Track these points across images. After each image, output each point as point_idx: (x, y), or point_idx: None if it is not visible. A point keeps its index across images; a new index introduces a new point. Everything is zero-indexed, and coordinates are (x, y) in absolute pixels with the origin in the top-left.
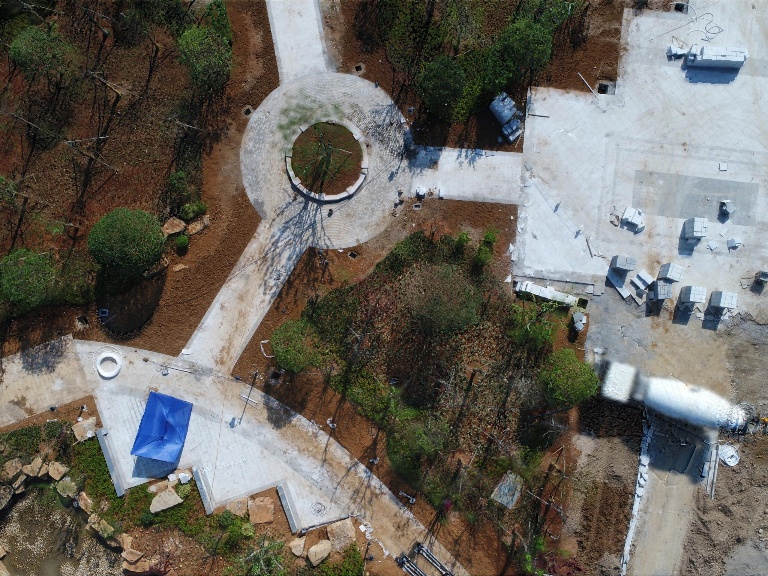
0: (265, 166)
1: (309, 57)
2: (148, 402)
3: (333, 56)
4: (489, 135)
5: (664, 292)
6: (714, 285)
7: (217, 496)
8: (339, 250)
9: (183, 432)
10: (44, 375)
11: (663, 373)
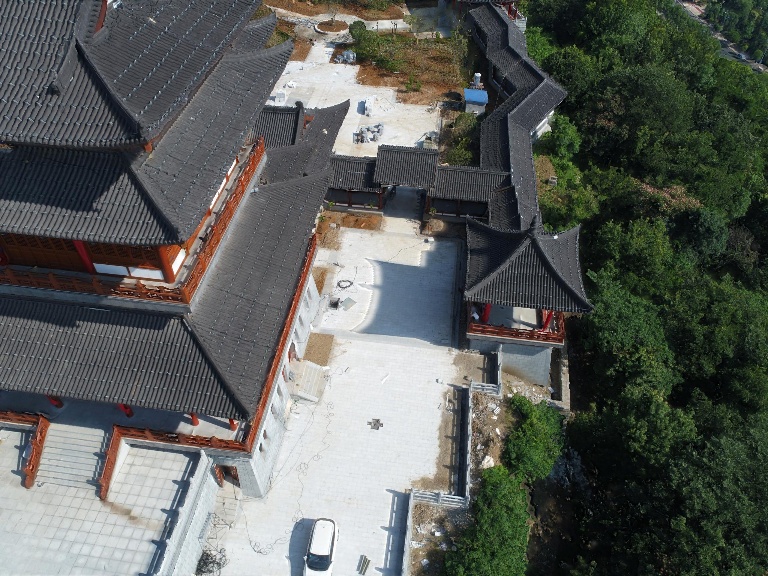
0: None
1: None
2: None
3: None
4: None
5: None
6: None
7: None
8: (293, 29)
9: None
10: None
11: None
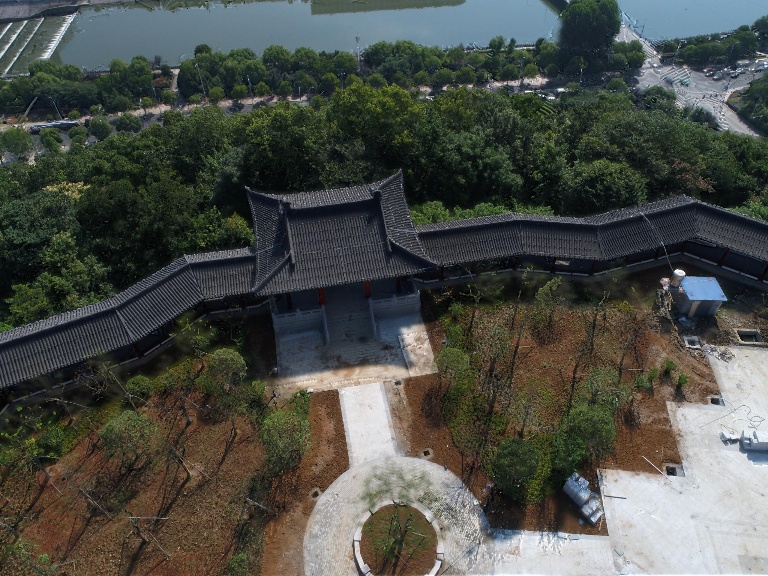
0: (330, 552)
1: (379, 443)
2: None
3: (401, 442)
4: (568, 517)
5: None
6: None
7: None
8: None
9: None
10: None
11: None
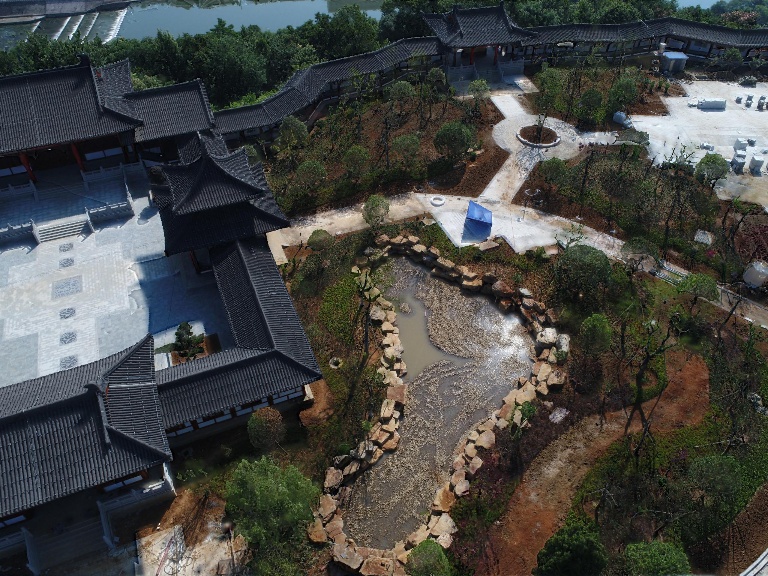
0: (507, 139)
1: None
2: (470, 203)
3: (528, 111)
4: (617, 127)
5: (740, 160)
6: (765, 164)
7: (519, 249)
8: None
9: (490, 222)
10: (399, 206)
11: (762, 193)
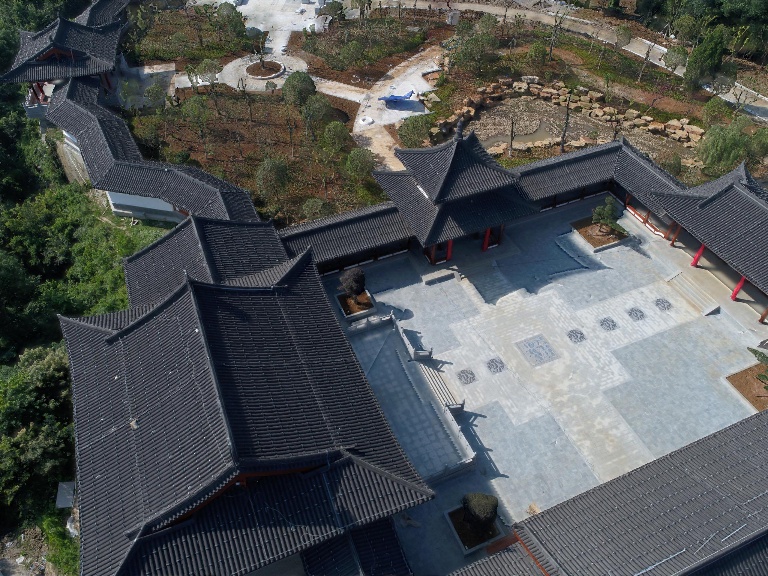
0: None
1: None
2: (383, 99)
3: None
4: None
5: None
6: None
7: None
8: (308, 67)
9: None
10: None
11: None
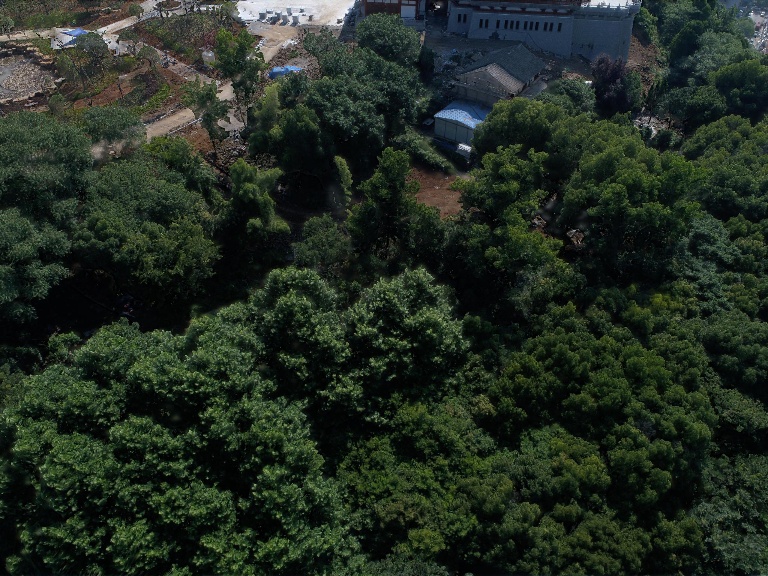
0: None
1: None
2: (77, 29)
3: None
4: None
5: None
6: None
7: None
8: None
9: None
10: None
11: None
